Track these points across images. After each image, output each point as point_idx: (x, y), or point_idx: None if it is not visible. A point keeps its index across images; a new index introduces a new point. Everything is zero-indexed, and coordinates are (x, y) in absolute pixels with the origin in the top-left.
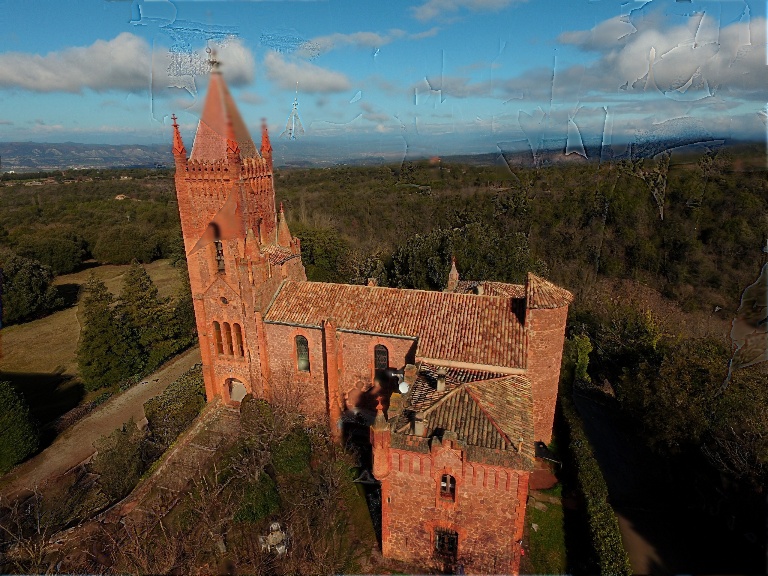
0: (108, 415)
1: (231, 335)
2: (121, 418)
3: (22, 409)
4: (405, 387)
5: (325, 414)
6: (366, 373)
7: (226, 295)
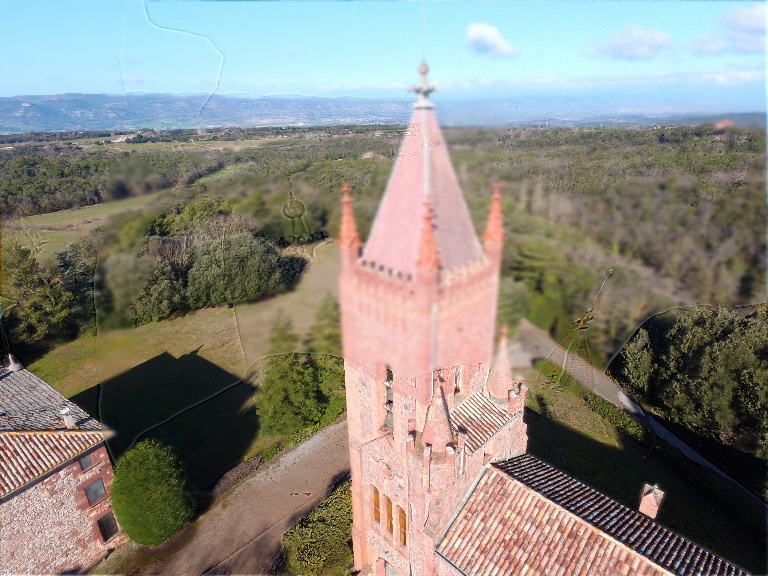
0: (270, 482)
1: (392, 514)
2: (279, 495)
3: (177, 483)
4: None
5: None
6: None
7: (391, 464)
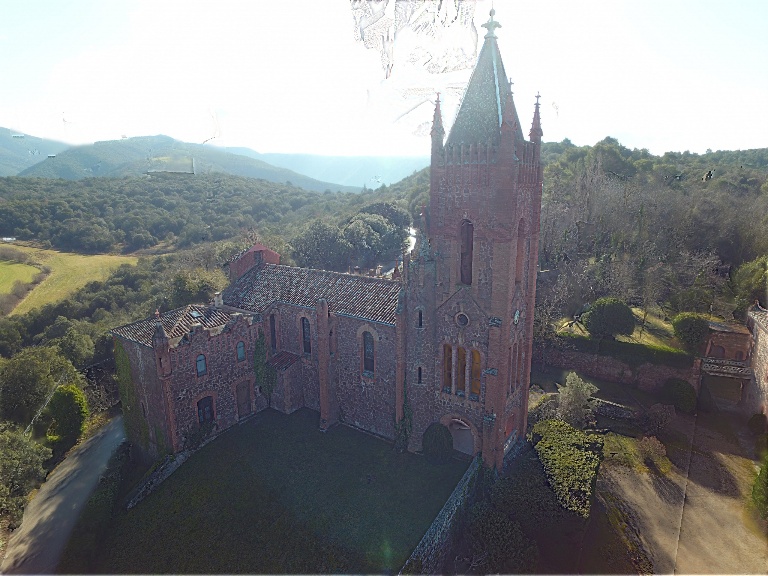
0: None
1: None
2: None
3: None
4: (377, 271)
5: None
6: None
7: None
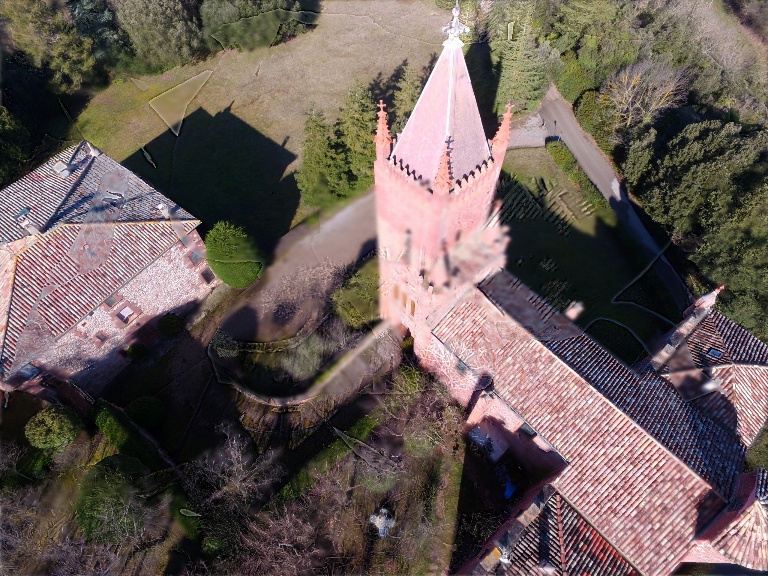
0: None
1: None
2: None
3: None
4: (506, 561)
5: (462, 418)
6: (510, 423)
7: None
